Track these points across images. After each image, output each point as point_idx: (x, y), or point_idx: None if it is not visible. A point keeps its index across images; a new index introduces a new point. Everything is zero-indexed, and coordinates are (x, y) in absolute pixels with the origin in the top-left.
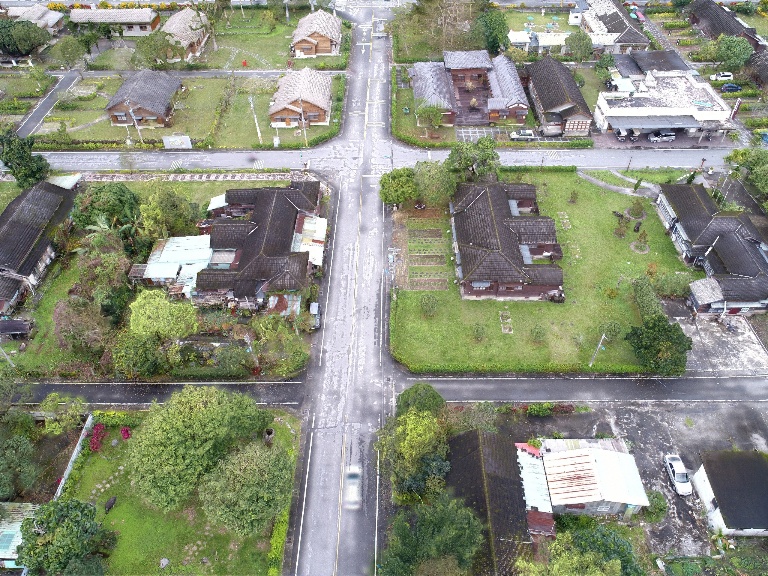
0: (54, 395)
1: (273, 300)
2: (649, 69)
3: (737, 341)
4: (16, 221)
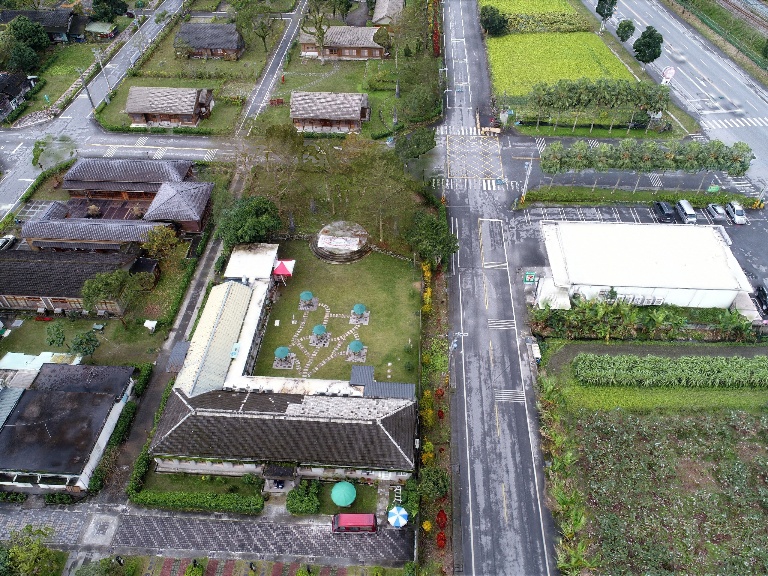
0: None
1: None
2: (31, 399)
3: None
4: (37, 13)
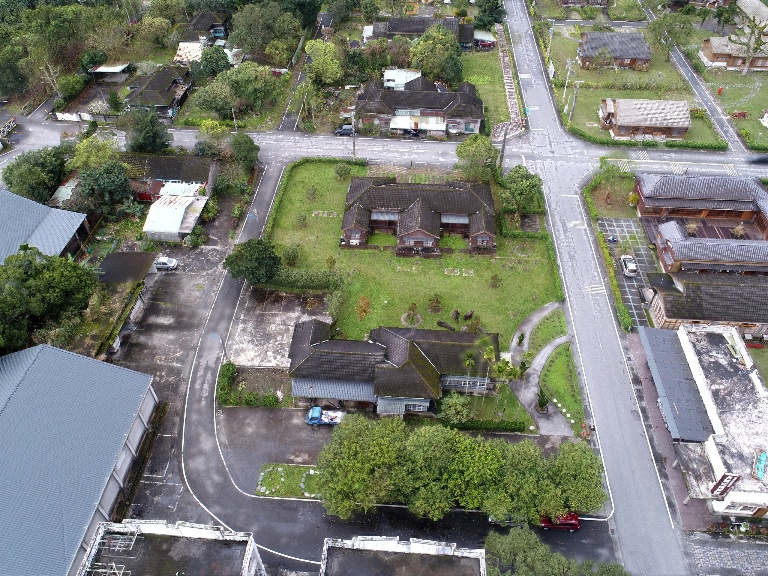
0: (284, 45)
1: (352, 107)
2: None
3: (267, 349)
4: (425, 21)
